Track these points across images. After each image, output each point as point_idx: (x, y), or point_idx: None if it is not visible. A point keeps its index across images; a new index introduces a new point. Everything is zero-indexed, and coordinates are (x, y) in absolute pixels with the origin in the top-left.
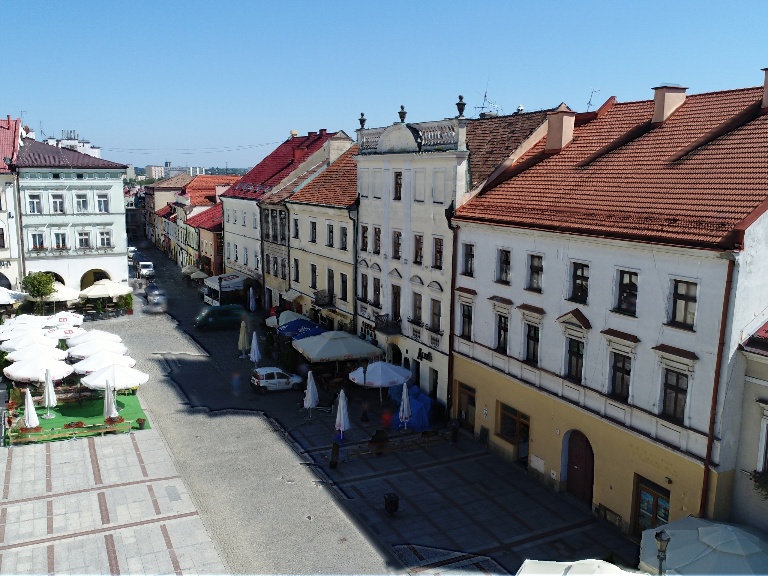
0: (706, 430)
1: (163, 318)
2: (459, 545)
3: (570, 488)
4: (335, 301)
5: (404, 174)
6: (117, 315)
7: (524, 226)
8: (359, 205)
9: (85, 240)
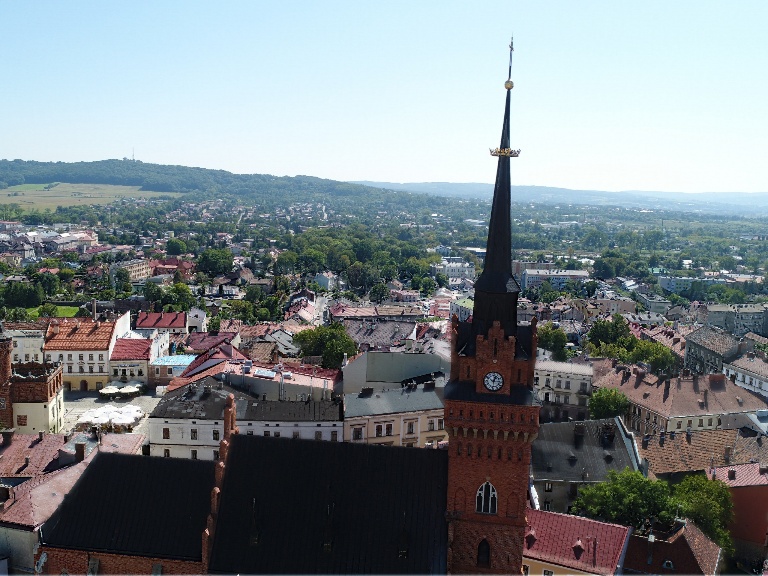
0: (107, 372)
1: None
2: (81, 398)
3: (82, 390)
4: None
5: (19, 342)
6: None
7: (68, 350)
8: None
9: None
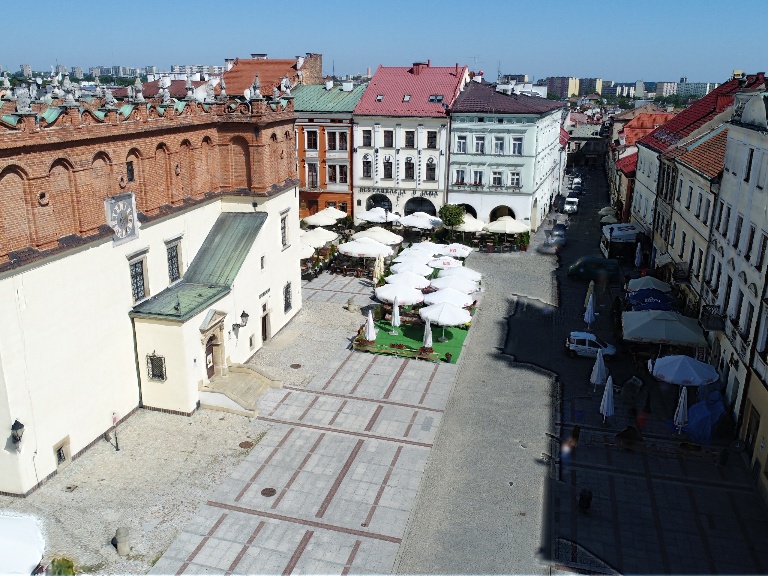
0: None
1: (549, 259)
2: (623, 565)
3: None
4: (691, 277)
5: (755, 153)
6: (511, 250)
7: None
8: (722, 178)
9: (499, 178)
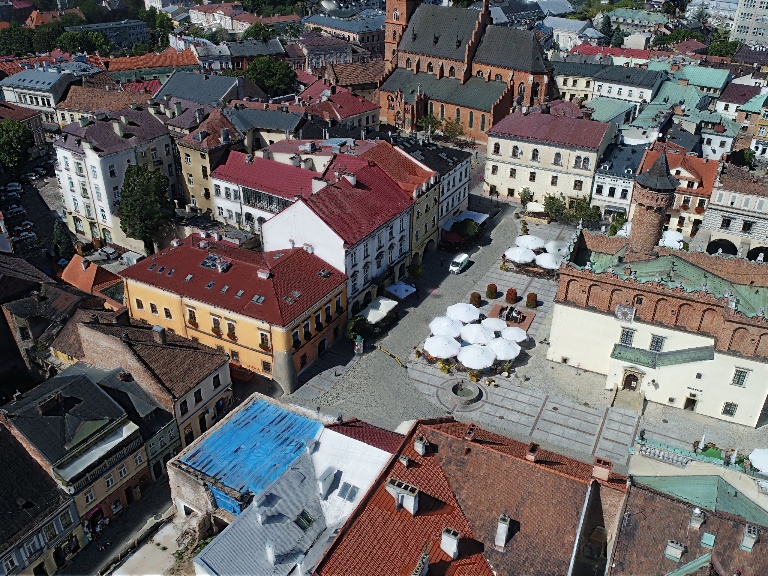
0: None
1: None
2: None
3: None
4: None
5: None
6: None
7: None
8: None
9: None
